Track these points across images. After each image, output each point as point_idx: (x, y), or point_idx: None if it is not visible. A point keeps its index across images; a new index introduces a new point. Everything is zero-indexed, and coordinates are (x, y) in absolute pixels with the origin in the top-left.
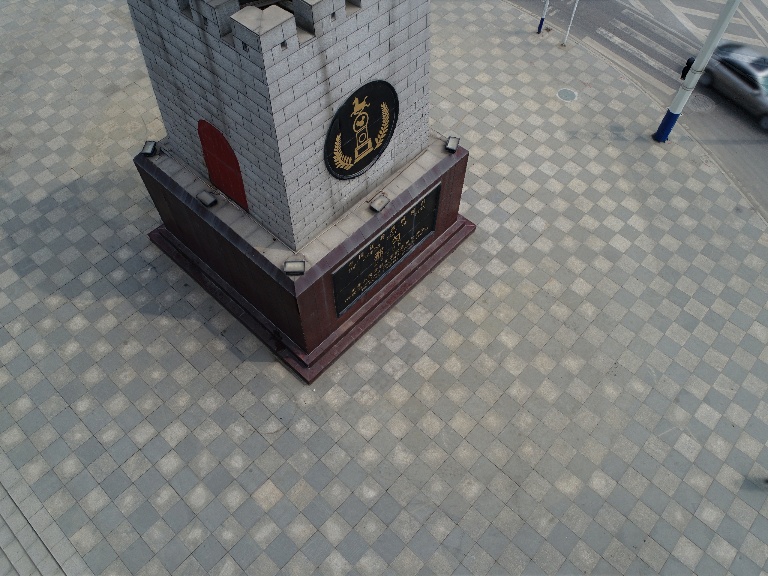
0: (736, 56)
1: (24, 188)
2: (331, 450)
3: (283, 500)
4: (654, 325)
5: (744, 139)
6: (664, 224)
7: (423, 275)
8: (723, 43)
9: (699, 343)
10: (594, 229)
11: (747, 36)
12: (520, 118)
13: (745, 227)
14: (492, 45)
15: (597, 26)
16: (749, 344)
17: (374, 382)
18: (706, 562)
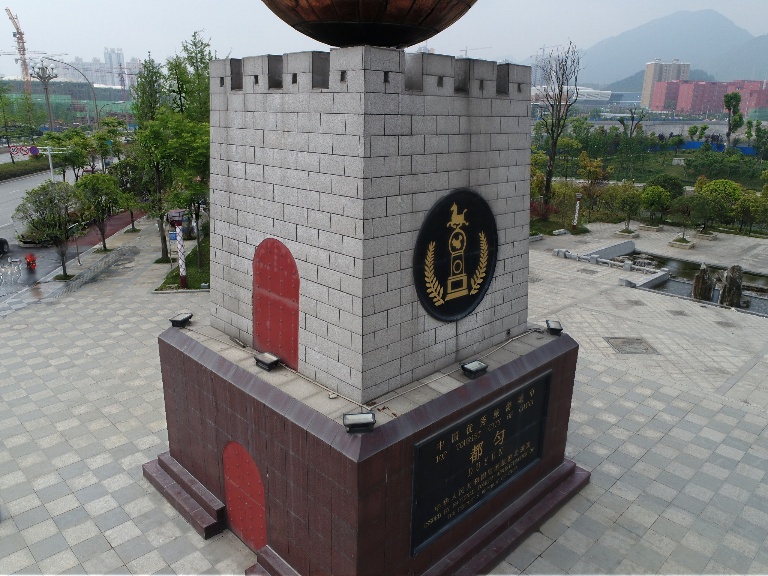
0: None
1: None
2: None
3: None
4: (29, 400)
5: None
6: None
7: None
8: None
9: (4, 390)
10: None
11: None
12: None
13: None
14: None
15: None
16: None
17: None
18: None
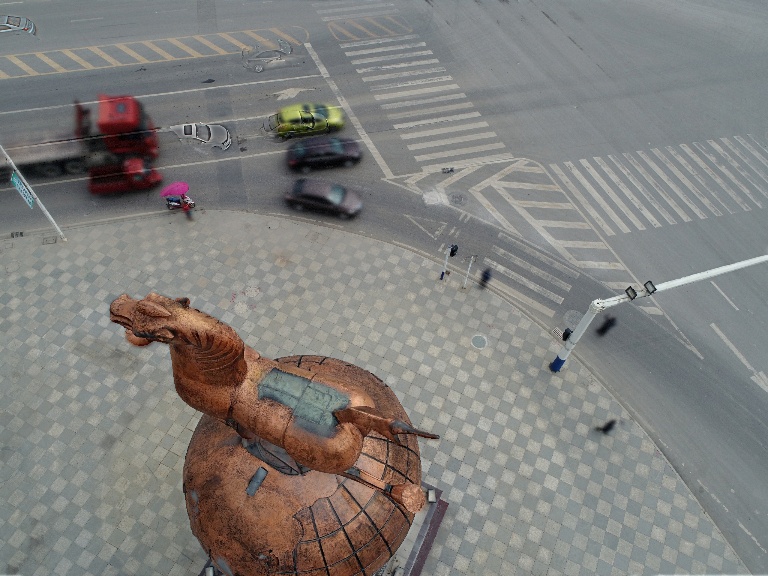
0: (589, 264)
1: None
2: None
3: None
4: (590, 553)
5: (612, 349)
6: (576, 454)
7: (423, 565)
8: (578, 252)
9: (622, 558)
10: (530, 475)
11: (593, 241)
12: (451, 377)
13: (630, 438)
14: (410, 303)
15: (483, 257)
16: (654, 548)
17: None
18: None
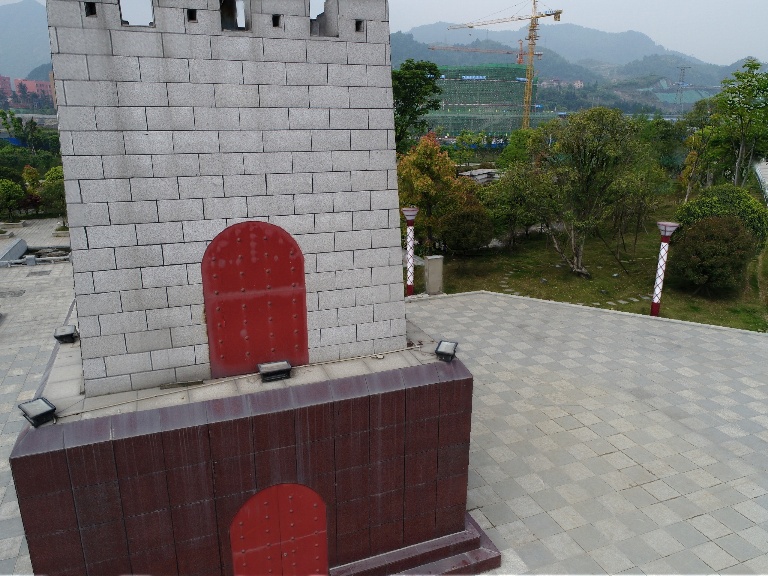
0: None
1: (481, 343)
2: (1, 430)
3: (14, 400)
4: None
5: None
6: None
7: None
8: None
9: None
10: None
11: None
12: None
13: None
14: None
15: None
16: None
17: (4, 475)
18: None
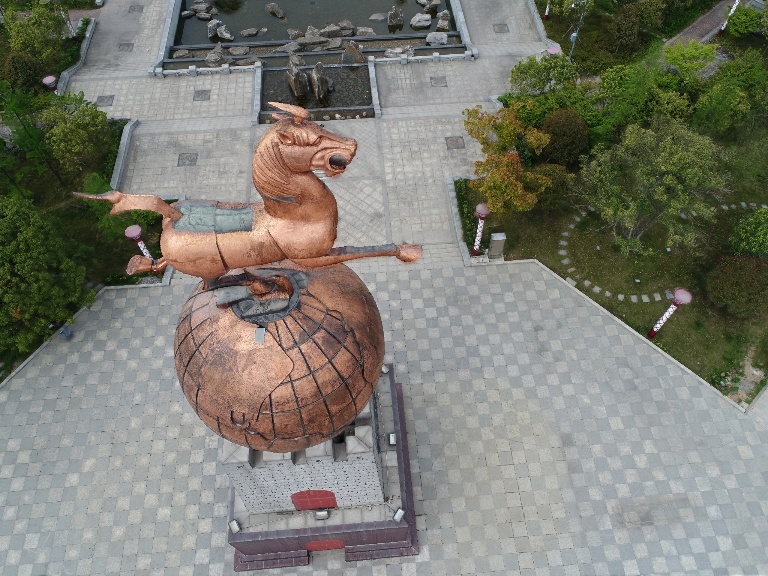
0: None
1: (497, 347)
2: None
3: None
4: None
5: None
6: None
7: None
8: None
9: None
10: None
11: None
12: None
13: None
14: None
15: None
16: None
17: None
18: (7, 488)
